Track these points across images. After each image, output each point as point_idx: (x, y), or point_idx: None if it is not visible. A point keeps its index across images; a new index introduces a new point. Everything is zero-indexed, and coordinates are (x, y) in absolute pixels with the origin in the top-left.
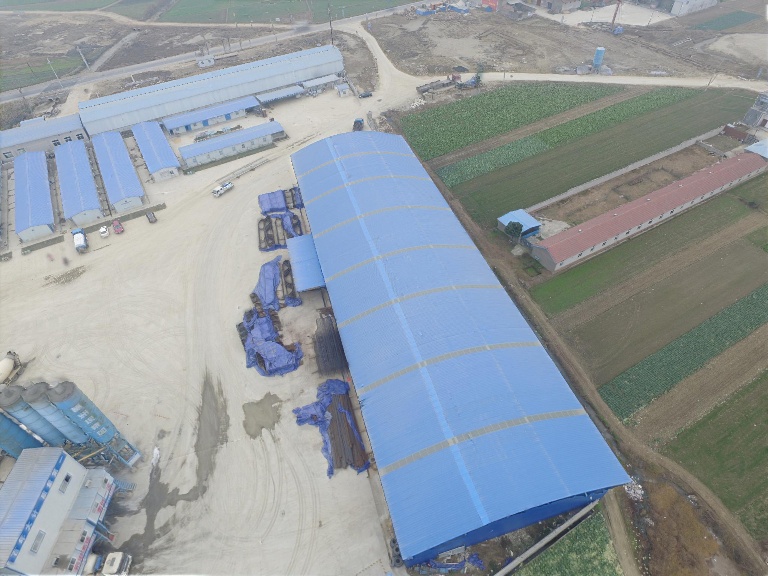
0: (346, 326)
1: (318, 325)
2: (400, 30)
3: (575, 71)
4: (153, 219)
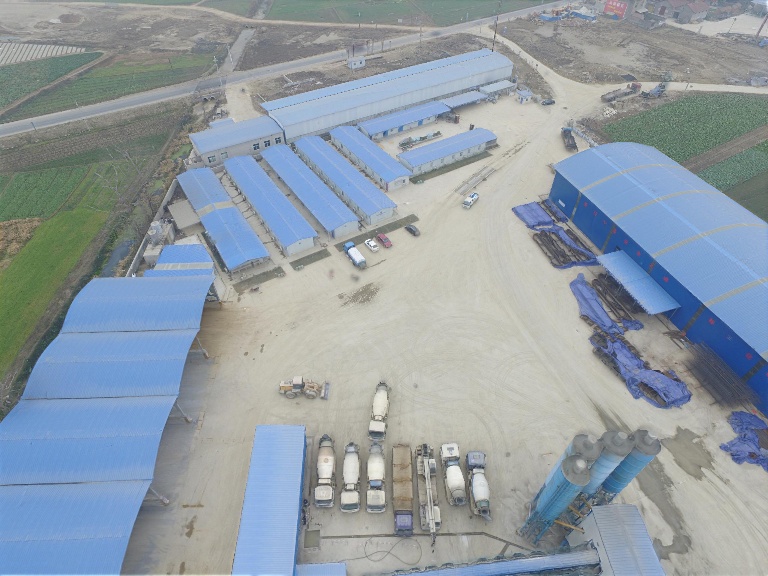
0: None
1: (700, 352)
2: (535, 35)
3: (747, 82)
4: (418, 232)
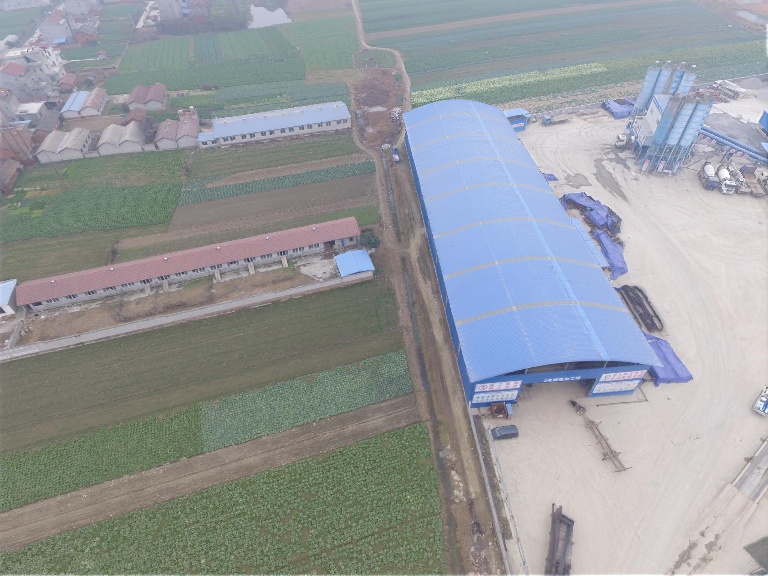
0: (533, 165)
1: None
2: None
3: None
4: None
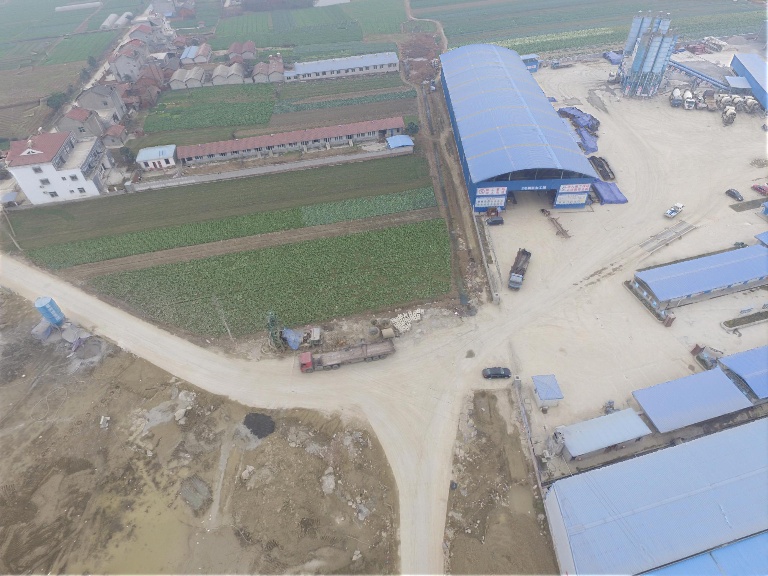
0: None
1: None
2: None
3: (78, 348)
4: None
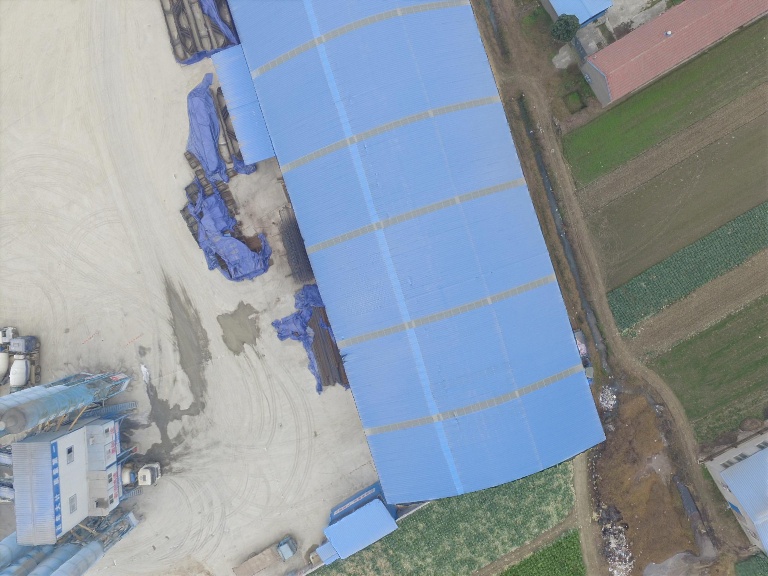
0: (317, 253)
1: (283, 221)
2: None
3: None
4: None
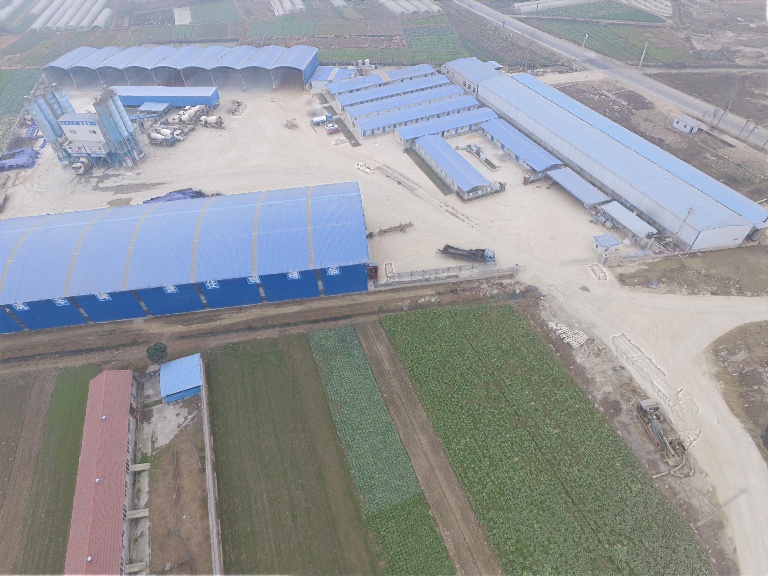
0: None
1: None
2: None
3: None
4: (335, 142)
